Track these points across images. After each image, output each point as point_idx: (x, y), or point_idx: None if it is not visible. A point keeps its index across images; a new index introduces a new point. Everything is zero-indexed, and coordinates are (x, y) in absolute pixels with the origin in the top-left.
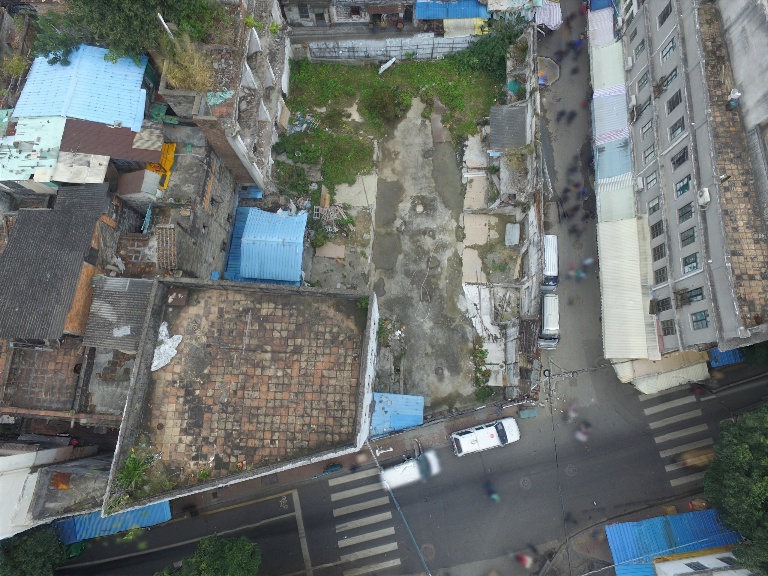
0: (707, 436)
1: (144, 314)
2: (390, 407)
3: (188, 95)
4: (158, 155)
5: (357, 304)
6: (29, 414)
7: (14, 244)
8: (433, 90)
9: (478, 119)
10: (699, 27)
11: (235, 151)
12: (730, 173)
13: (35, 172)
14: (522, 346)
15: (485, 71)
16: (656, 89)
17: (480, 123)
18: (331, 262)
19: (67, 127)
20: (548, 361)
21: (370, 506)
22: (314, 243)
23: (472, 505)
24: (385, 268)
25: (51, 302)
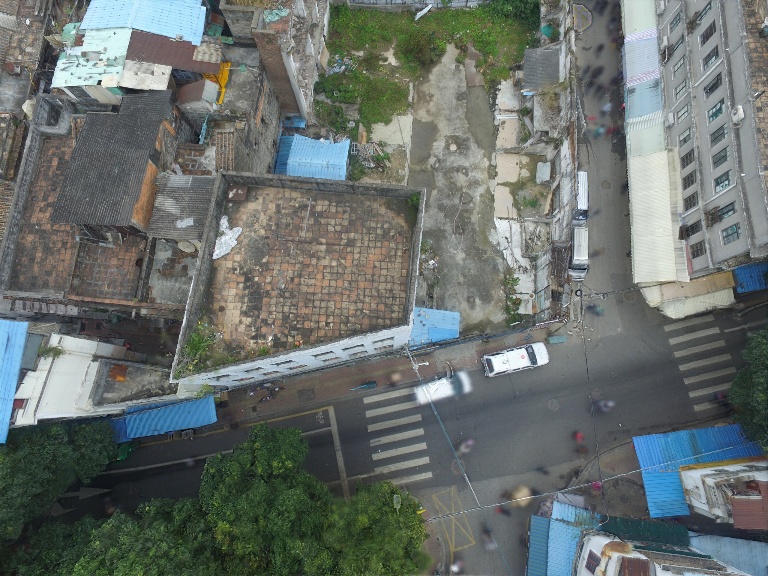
0: (730, 365)
1: (206, 207)
2: (428, 321)
3: (247, 10)
4: (217, 67)
5: (408, 201)
6: (93, 304)
7: (83, 142)
8: (467, 37)
9: (511, 64)
10: None
11: (287, 70)
12: (763, 95)
13: (102, 78)
14: (554, 271)
15: (518, 19)
16: (689, 26)
17: (513, 68)
18: None
19: (132, 38)
20: None
21: (403, 423)
22: (351, 177)
23: (501, 424)
24: None
25: (120, 193)
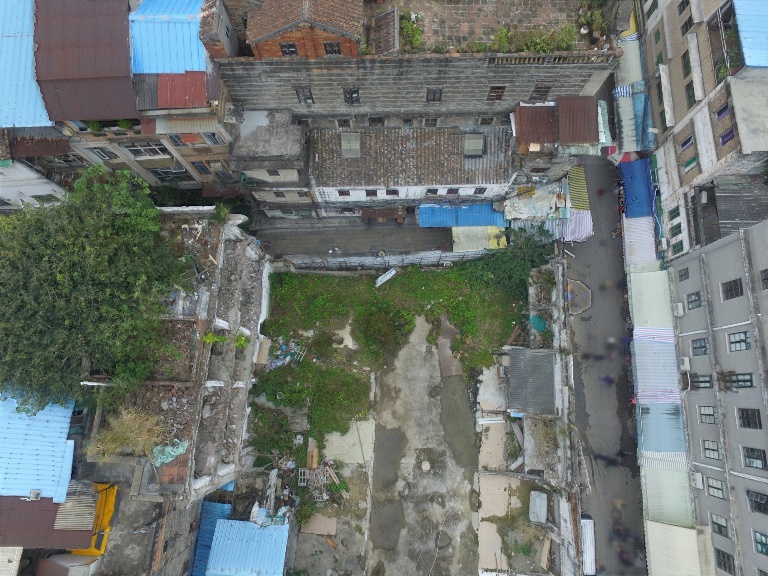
0: None
1: None
2: None
3: (126, 463)
4: (88, 537)
5: None
6: None
7: None
8: (440, 307)
9: (494, 349)
10: None
11: None
12: None
13: None
14: None
15: None
16: (720, 377)
17: (497, 353)
18: (320, 540)
19: None
20: None
21: None
22: (299, 516)
23: None
24: (385, 547)
25: None
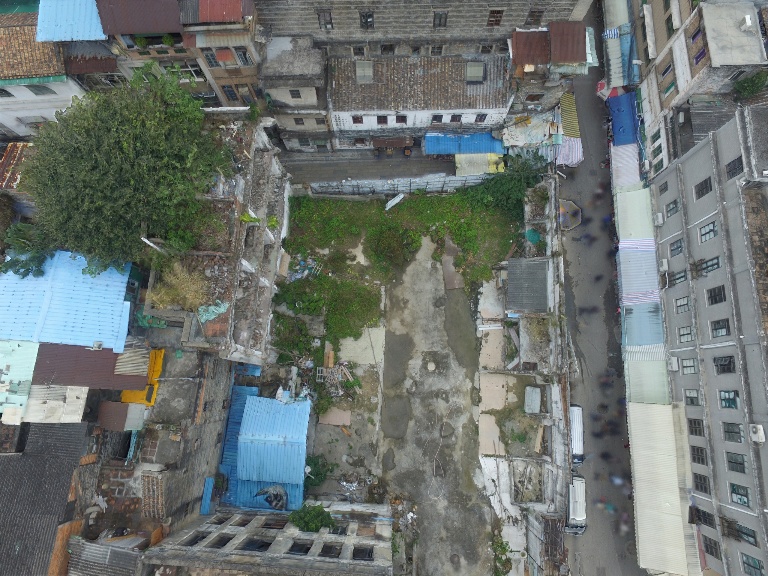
0: None
1: None
2: None
3: (177, 316)
4: (143, 381)
5: None
6: None
7: None
8: (444, 228)
9: (493, 264)
10: (747, 227)
11: None
12: None
13: (3, 411)
14: (547, 549)
15: (500, 208)
16: (693, 267)
17: (495, 268)
18: (336, 430)
19: (40, 354)
20: (575, 558)
21: None
22: (317, 409)
23: None
24: (395, 437)
25: None
